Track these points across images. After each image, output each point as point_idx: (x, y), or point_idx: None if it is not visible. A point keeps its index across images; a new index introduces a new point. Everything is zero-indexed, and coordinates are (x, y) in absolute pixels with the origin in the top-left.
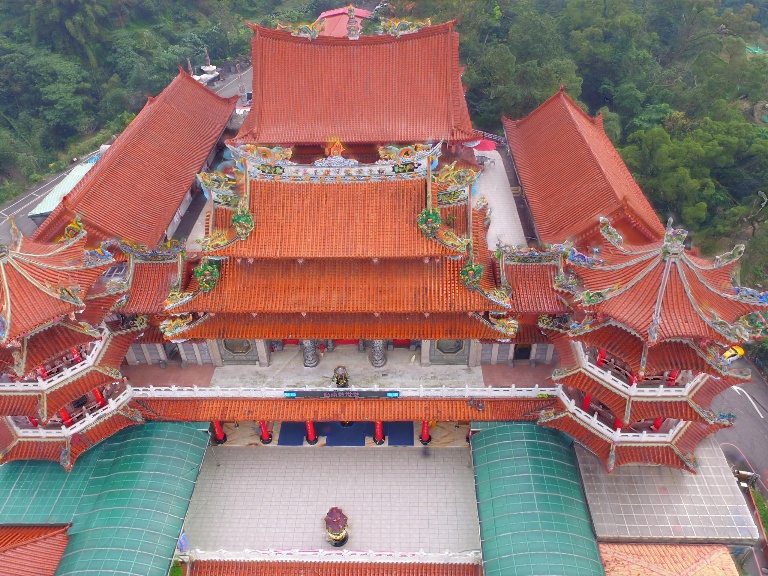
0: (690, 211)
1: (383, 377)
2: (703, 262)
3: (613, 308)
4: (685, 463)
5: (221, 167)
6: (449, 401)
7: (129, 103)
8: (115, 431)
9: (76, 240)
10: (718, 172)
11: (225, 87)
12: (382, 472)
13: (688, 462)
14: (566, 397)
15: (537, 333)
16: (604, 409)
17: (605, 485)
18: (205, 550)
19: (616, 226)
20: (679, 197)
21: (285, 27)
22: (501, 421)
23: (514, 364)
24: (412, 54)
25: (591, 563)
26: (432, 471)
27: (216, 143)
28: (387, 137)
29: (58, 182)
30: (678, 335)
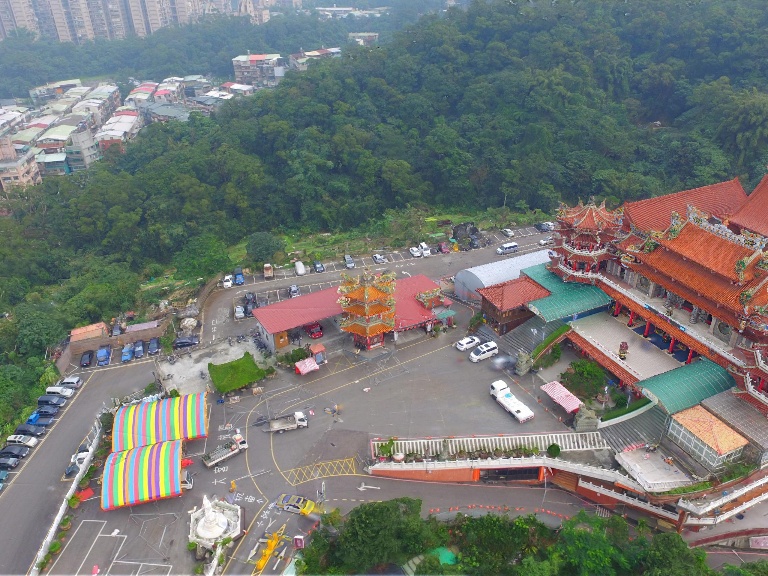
0: None
1: (688, 326)
2: None
3: None
4: None
5: None
6: (703, 345)
7: None
8: (584, 282)
9: (618, 215)
10: None
11: None
12: (659, 359)
13: None
14: None
15: None
16: None
17: (727, 399)
18: None
19: None
20: None
21: None
22: None
23: None
24: None
25: (687, 400)
26: None
27: None
28: None
29: None
30: None
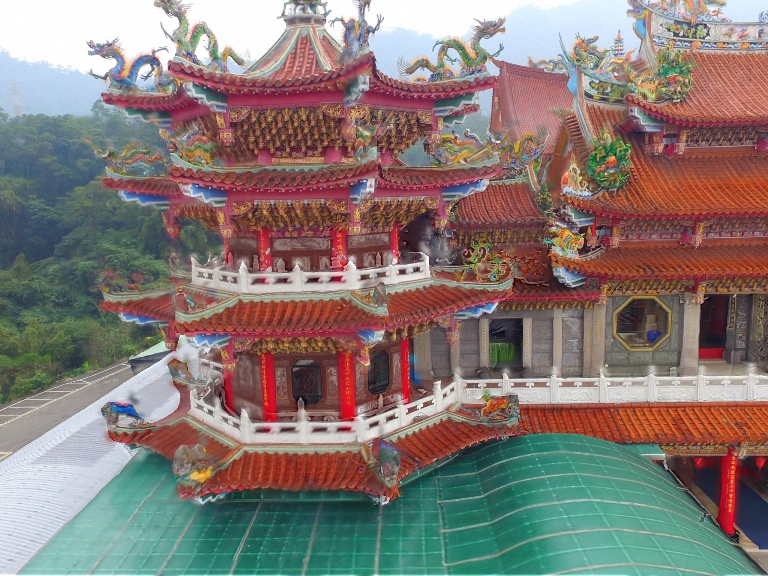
0: None
1: None
2: None
3: None
4: None
5: None
6: None
7: None
8: (457, 448)
9: None
10: None
11: None
12: None
13: None
14: None
15: None
16: None
17: None
18: None
19: None
20: None
21: (537, 62)
22: None
23: None
24: None
25: None
26: None
27: None
28: None
29: None
30: None
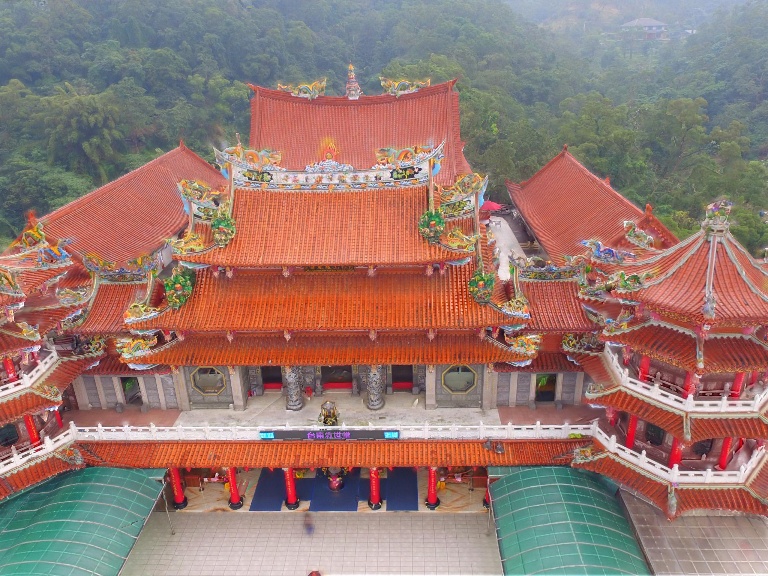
0: None
1: (380, 420)
2: None
3: (654, 295)
4: (767, 507)
5: None
6: (460, 443)
7: None
8: (46, 477)
9: (34, 250)
10: None
11: None
12: (378, 541)
13: None
14: (604, 434)
15: (562, 360)
16: (653, 445)
17: (667, 538)
18: None
19: None
20: None
21: (285, 87)
22: (526, 466)
23: (537, 406)
24: (412, 112)
25: None
26: (441, 540)
27: None
28: None
29: None
30: (739, 317)
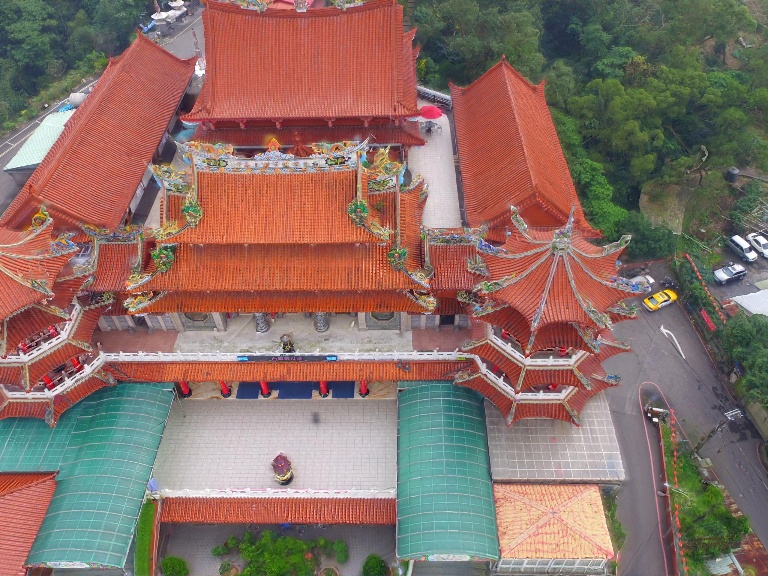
0: (638, 163)
1: (325, 341)
2: (595, 249)
3: (508, 295)
4: (572, 418)
5: (180, 137)
6: (380, 363)
7: (97, 42)
8: (92, 392)
9: (43, 228)
10: (674, 119)
11: (194, 23)
12: (325, 421)
13: (574, 417)
14: (480, 361)
15: (457, 305)
16: None
17: (505, 436)
18: (174, 489)
19: (530, 210)
20: (631, 147)
21: None
22: (424, 381)
23: (440, 329)
24: (358, 27)
25: (484, 501)
26: (368, 420)
27: (175, 111)
28: (333, 112)
29: (31, 130)
30: (558, 320)
